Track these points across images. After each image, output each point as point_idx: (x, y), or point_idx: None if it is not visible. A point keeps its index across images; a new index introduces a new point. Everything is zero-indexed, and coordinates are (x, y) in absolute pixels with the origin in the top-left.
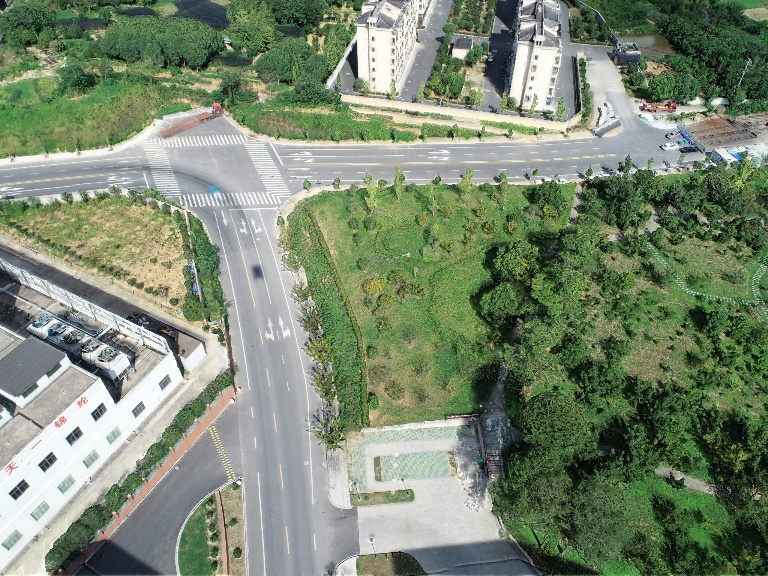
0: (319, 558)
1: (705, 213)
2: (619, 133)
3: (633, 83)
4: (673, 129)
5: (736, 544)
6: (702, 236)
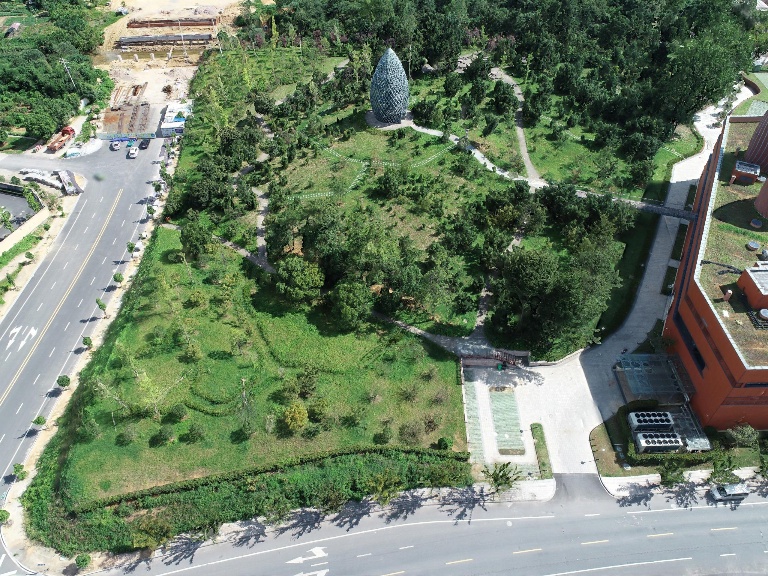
0: (607, 511)
1: (269, 151)
2: (85, 178)
3: (2, 143)
4: (104, 143)
5: (554, 241)
6: (280, 168)
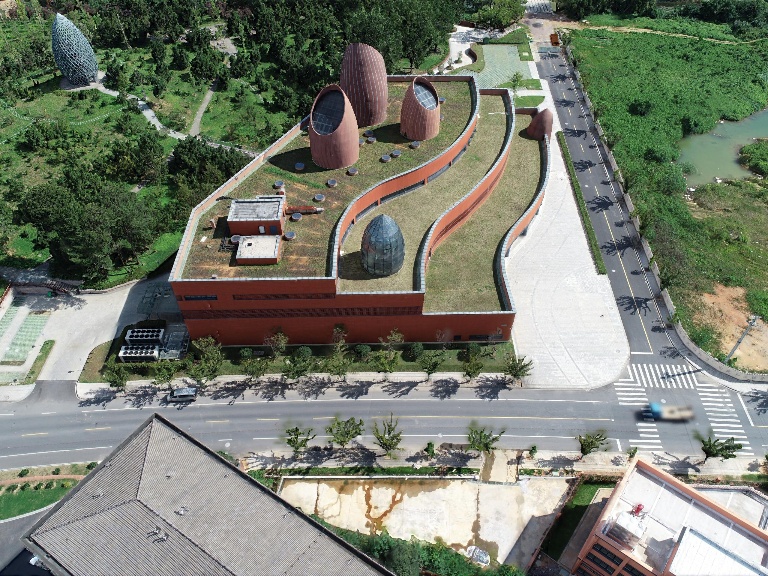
0: (64, 410)
1: None
2: None
3: None
4: None
5: (173, 189)
6: None
